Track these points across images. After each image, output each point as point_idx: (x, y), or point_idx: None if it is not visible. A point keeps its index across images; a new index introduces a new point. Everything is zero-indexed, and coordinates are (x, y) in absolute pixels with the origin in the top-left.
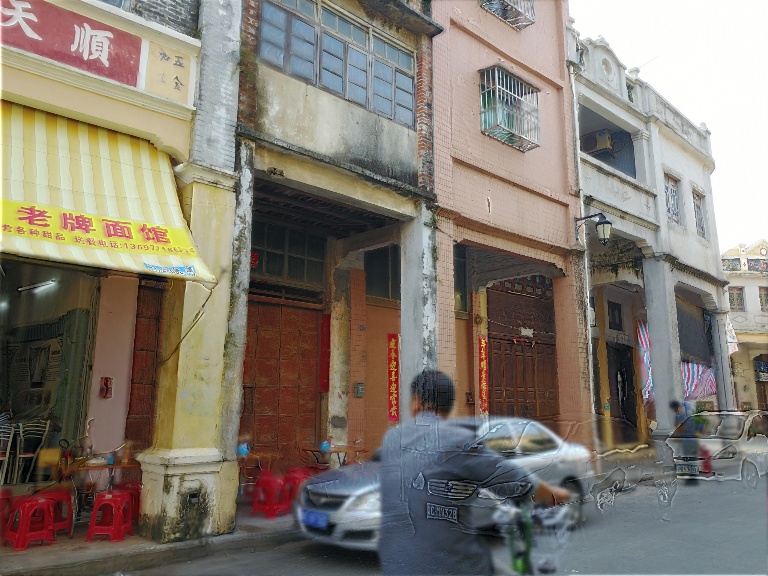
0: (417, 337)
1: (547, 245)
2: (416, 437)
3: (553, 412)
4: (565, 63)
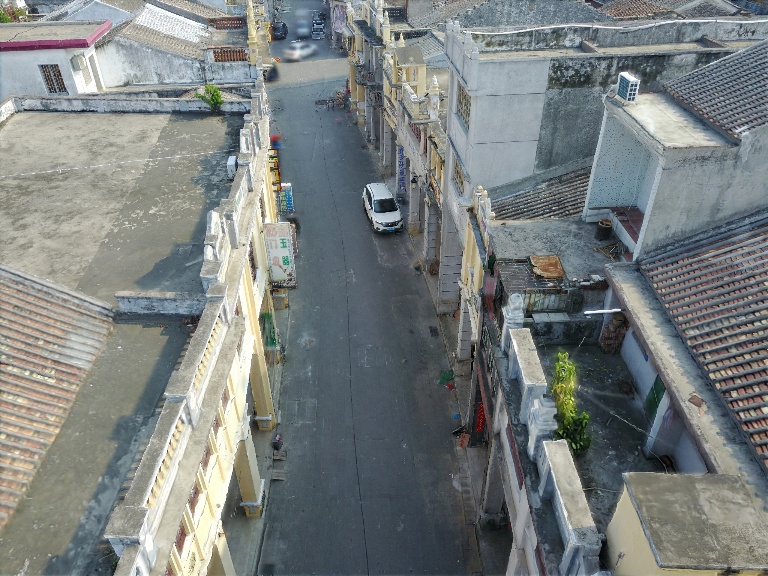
0: None
1: None
2: None
3: None
4: None
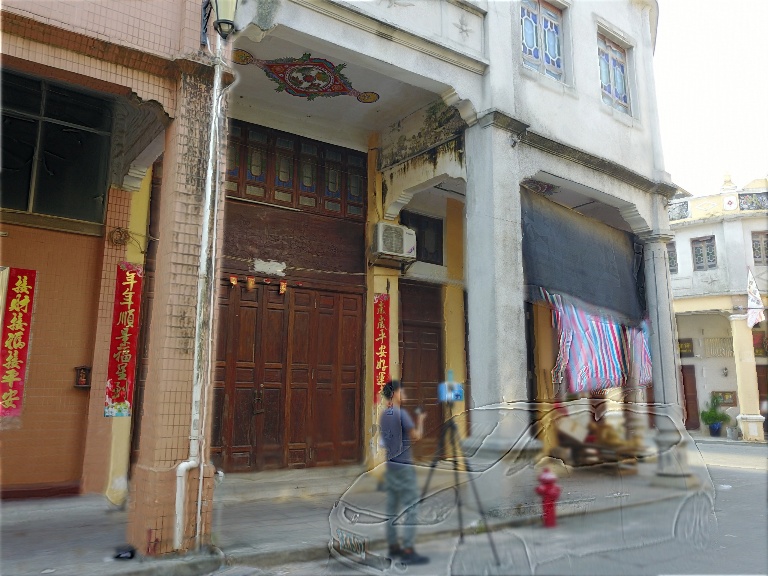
0: None
1: (84, 39)
2: None
3: (328, 404)
4: None
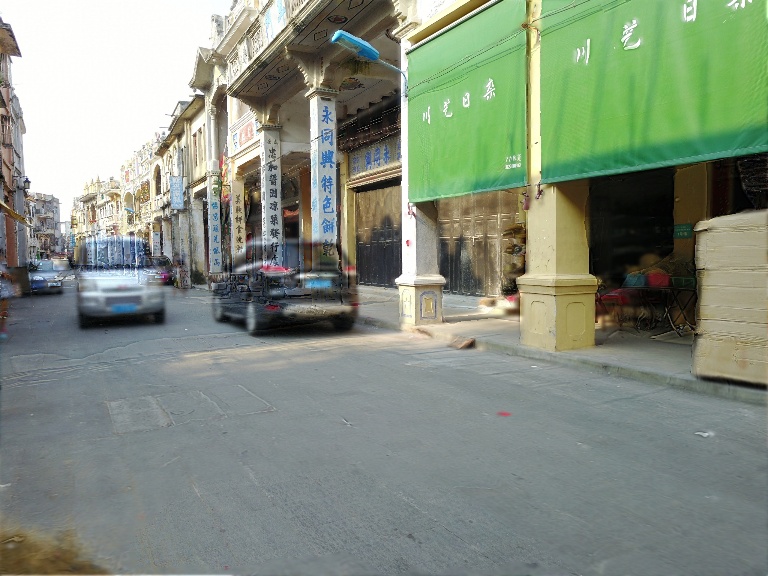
0: (1, 232)
1: None
2: (2, 269)
3: None
4: (9, 99)
